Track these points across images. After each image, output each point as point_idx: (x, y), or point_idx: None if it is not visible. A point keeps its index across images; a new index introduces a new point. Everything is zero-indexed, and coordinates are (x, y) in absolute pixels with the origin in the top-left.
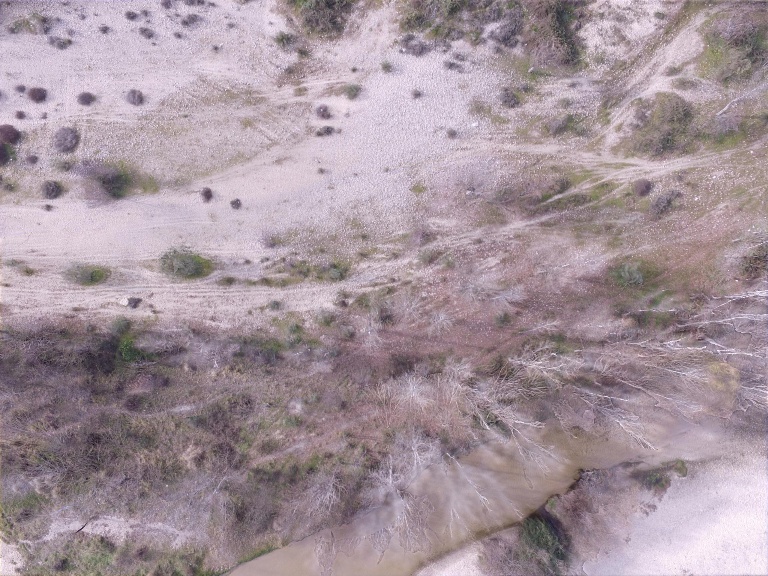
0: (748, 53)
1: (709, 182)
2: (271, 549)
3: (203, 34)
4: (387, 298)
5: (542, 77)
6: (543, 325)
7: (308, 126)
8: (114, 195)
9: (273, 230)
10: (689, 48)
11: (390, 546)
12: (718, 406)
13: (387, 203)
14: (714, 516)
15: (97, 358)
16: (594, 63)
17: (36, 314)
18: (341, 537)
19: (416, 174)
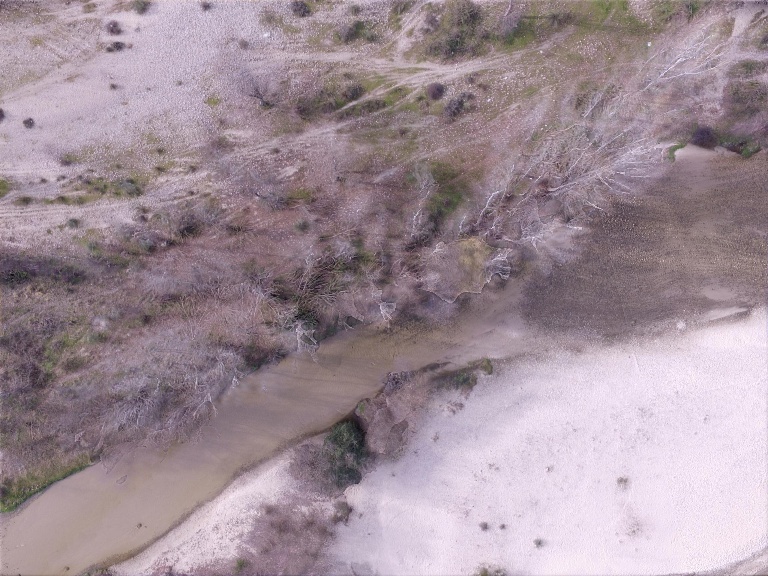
0: None
1: (501, 83)
2: (82, 467)
3: None
4: (186, 211)
5: None
6: (343, 231)
7: (99, 42)
8: None
9: (68, 148)
10: None
11: (203, 458)
12: (468, 281)
13: (182, 116)
14: (519, 411)
15: None
16: None
17: None
18: (153, 452)
19: (210, 86)
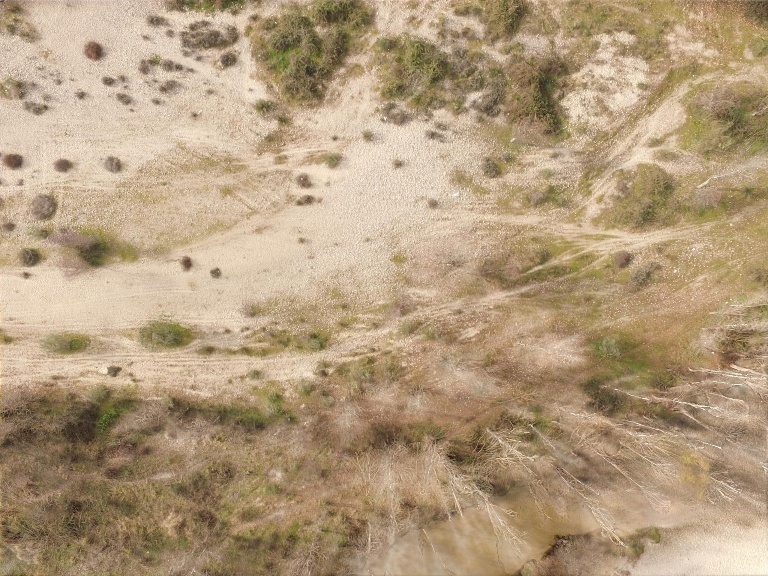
0: (730, 127)
1: (688, 254)
2: None
3: (182, 100)
4: (367, 368)
5: (524, 147)
6: (521, 395)
7: (288, 195)
8: (92, 264)
9: (253, 299)
10: (672, 119)
11: None
12: (687, 496)
13: (367, 273)
14: None
15: (77, 427)
16: (576, 133)
17: (15, 382)
18: None
19: (397, 244)
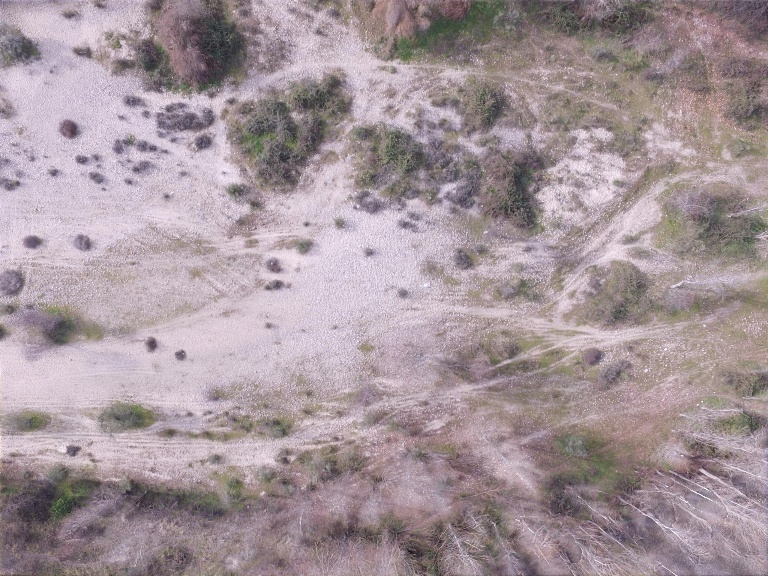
0: (705, 229)
1: (660, 354)
2: None
3: (154, 181)
4: (330, 457)
5: (497, 239)
6: (486, 491)
7: (257, 279)
8: (57, 341)
9: (217, 383)
10: (647, 217)
11: None
12: None
13: (334, 361)
14: None
15: (32, 507)
16: (550, 228)
17: None
18: None
19: (365, 333)
